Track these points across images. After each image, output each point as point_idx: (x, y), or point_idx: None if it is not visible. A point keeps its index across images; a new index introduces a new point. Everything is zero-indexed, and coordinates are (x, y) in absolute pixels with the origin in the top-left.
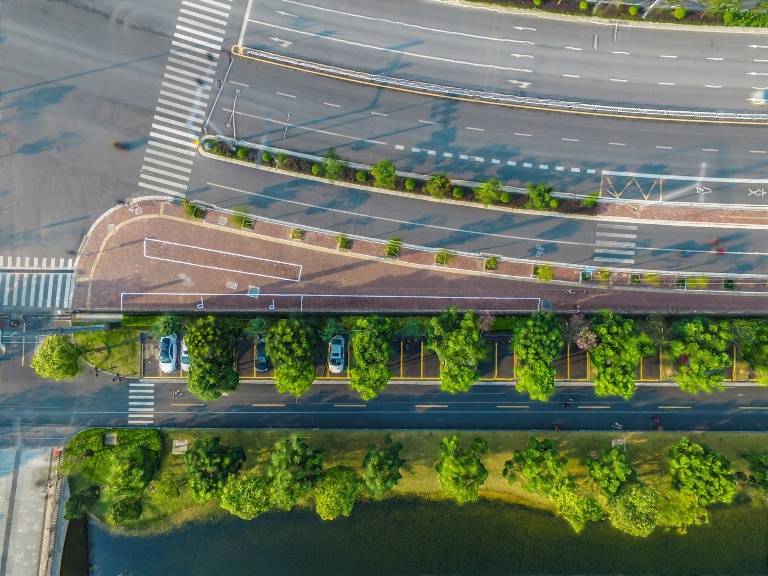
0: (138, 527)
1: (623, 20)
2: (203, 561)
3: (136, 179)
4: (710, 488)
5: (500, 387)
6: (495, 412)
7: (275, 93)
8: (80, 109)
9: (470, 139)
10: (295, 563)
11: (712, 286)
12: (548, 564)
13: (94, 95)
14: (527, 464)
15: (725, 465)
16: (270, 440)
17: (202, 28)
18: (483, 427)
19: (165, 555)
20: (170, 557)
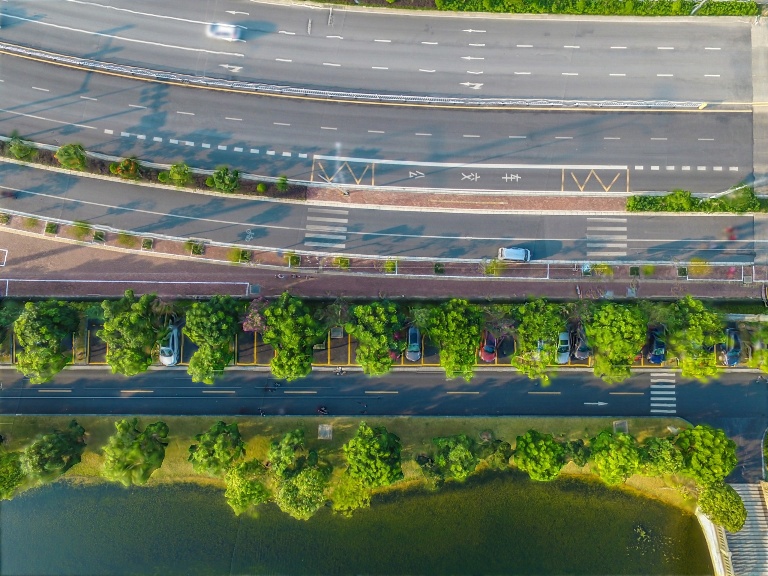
0: None
1: (337, 4)
2: None
3: None
4: (369, 471)
5: None
6: (201, 397)
7: None
8: None
9: (180, 123)
10: (4, 550)
11: (423, 271)
12: (260, 550)
13: None
14: None
15: (393, 448)
16: None
17: None
18: (188, 412)
19: None
20: None
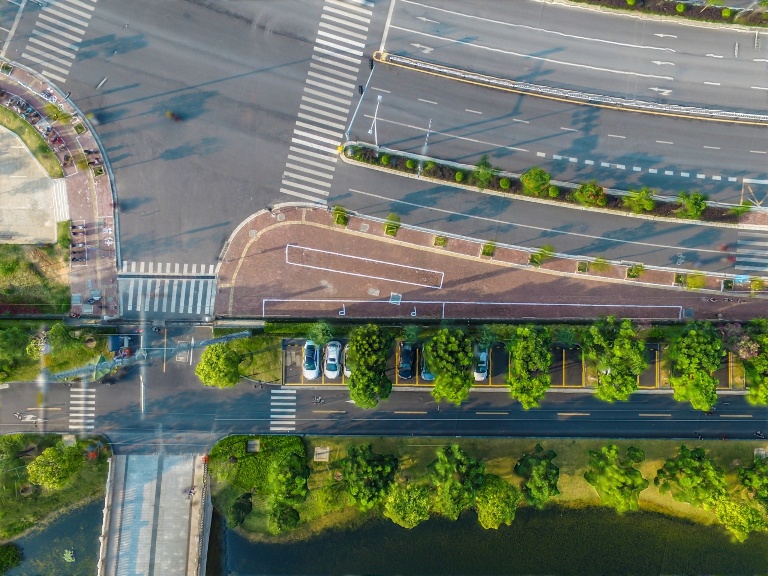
0: (278, 534)
1: (764, 28)
2: (342, 568)
3: (278, 185)
4: None
5: (642, 395)
6: (637, 420)
7: (417, 99)
8: (222, 115)
9: (611, 146)
10: (434, 570)
11: None
12: (687, 572)
13: (236, 101)
14: (686, 473)
15: None
16: (412, 447)
17: (344, 34)
18: (626, 435)
19: (304, 562)
20: (309, 564)
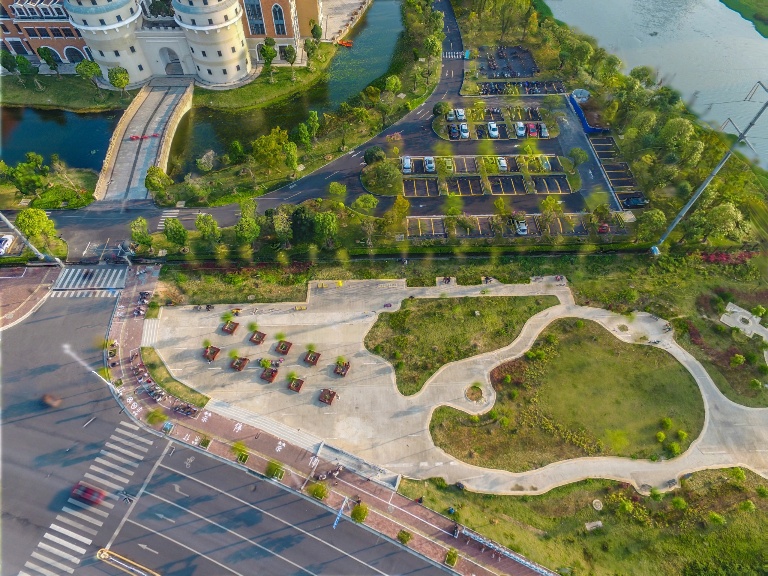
0: None
1: None
2: (44, 160)
3: None
4: None
5: None
6: None
7: None
8: None
9: None
10: None
11: None
12: None
13: None
14: None
15: None
16: None
17: None
18: None
19: (65, 162)
20: None
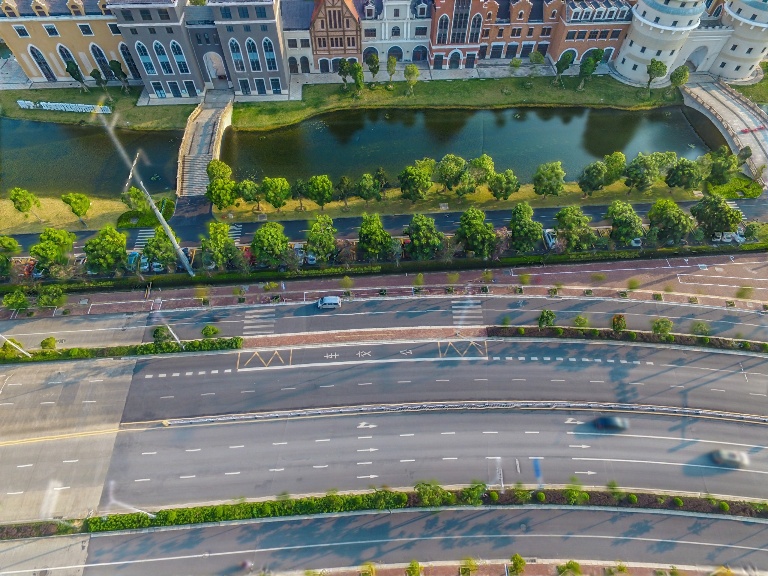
0: None
1: None
2: None
3: None
4: None
5: None
6: None
7: (767, 396)
8: None
9: (598, 374)
10: None
11: (394, 291)
12: None
13: None
14: None
15: (406, 184)
16: (650, 199)
17: None
18: None
19: (676, 156)
20: None
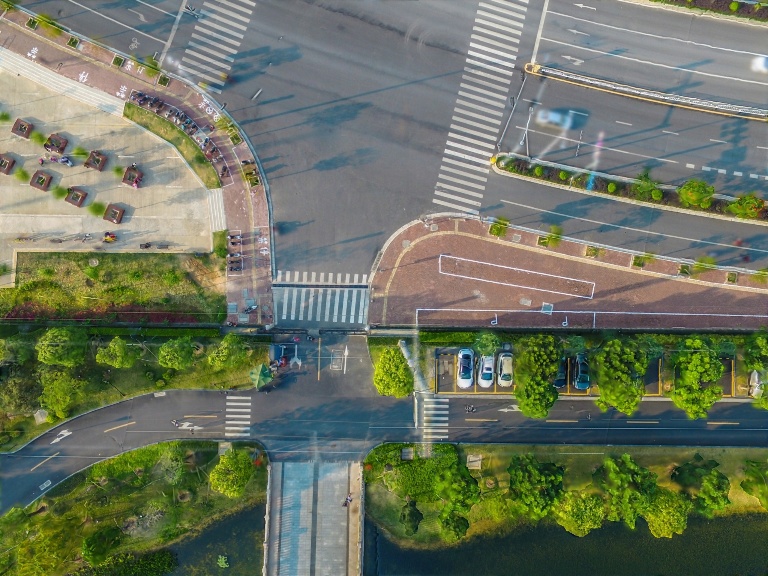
0: (428, 540)
1: None
2: (491, 574)
3: (430, 196)
4: None
5: None
6: None
7: (568, 111)
8: (375, 126)
9: (760, 158)
10: None
11: None
12: None
13: (389, 112)
14: None
15: None
16: (564, 456)
17: (496, 46)
18: None
19: (454, 568)
20: (459, 570)
